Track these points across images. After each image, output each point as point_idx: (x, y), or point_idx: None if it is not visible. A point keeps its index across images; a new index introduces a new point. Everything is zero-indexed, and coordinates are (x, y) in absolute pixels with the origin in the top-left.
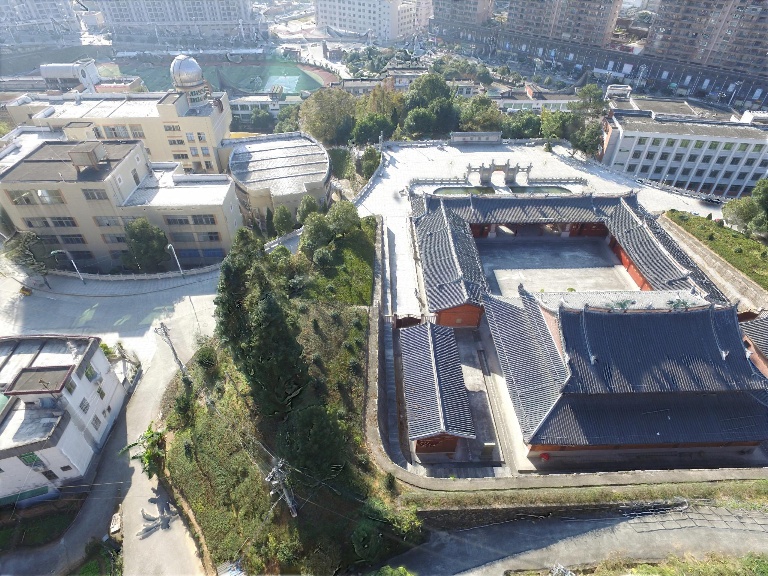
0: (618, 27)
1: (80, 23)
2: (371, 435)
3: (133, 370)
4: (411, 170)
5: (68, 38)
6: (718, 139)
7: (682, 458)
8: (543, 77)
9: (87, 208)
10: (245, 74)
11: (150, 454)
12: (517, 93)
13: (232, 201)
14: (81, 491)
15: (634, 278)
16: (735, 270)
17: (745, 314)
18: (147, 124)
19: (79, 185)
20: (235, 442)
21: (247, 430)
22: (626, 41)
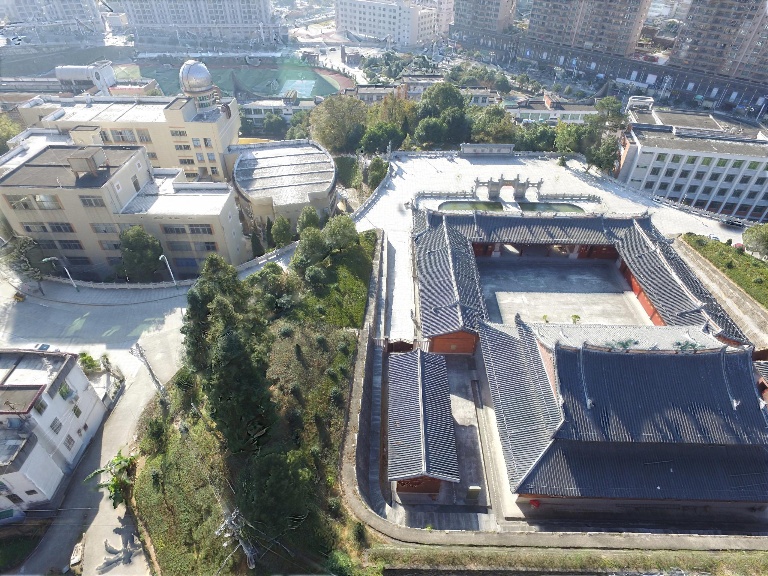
0: (643, 36)
1: (105, 24)
2: (347, 474)
3: (116, 385)
4: (418, 182)
5: (92, 39)
6: (742, 158)
7: (685, 512)
8: (563, 86)
9: (84, 214)
10: (262, 77)
11: (117, 482)
12: (535, 102)
13: (231, 210)
14: (46, 516)
15: (644, 306)
16: (754, 302)
17: (763, 352)
18: (154, 129)
19: (76, 191)
20: (202, 476)
21: (215, 464)
22: (651, 51)
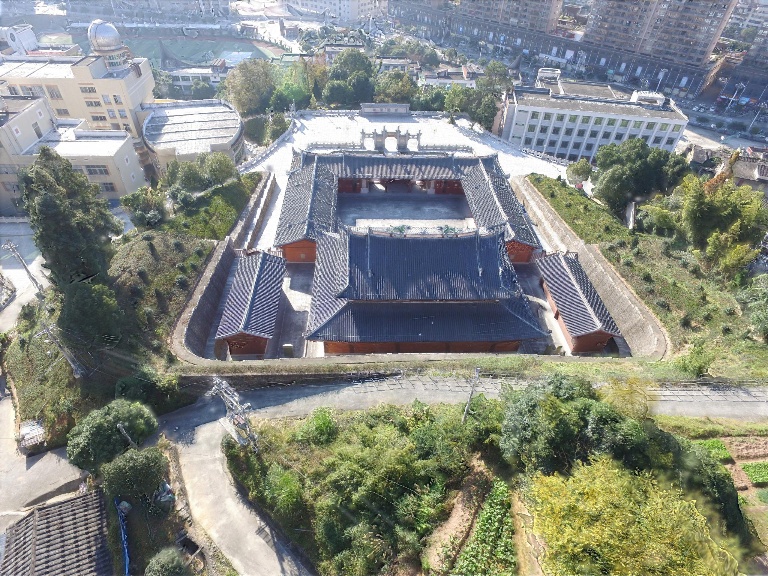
0: (567, 14)
1: None
2: (178, 332)
3: (6, 294)
4: (317, 136)
5: (22, 7)
6: (601, 115)
7: None
8: (488, 60)
9: None
10: (199, 48)
11: None
12: (454, 73)
13: (129, 155)
14: None
15: None
16: (562, 221)
17: None
18: (63, 85)
19: None
20: None
21: None
22: (572, 28)
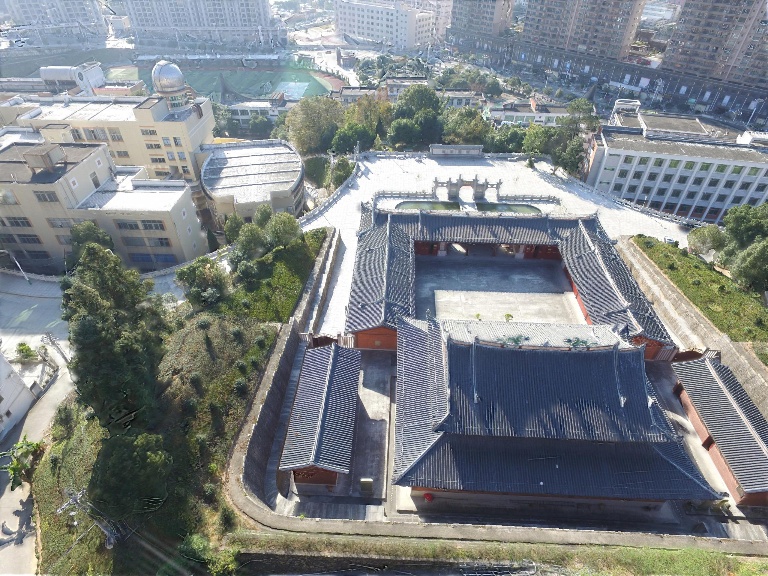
0: (639, 39)
1: (108, 27)
2: (235, 463)
3: (48, 374)
4: (382, 182)
5: (94, 41)
6: (709, 160)
7: (579, 510)
8: (554, 89)
9: (40, 209)
10: (257, 79)
11: (18, 465)
12: (521, 105)
13: (186, 207)
14: None
15: (581, 306)
16: (690, 304)
17: (688, 353)
18: (125, 128)
19: (30, 187)
20: (92, 461)
21: None
22: (646, 54)
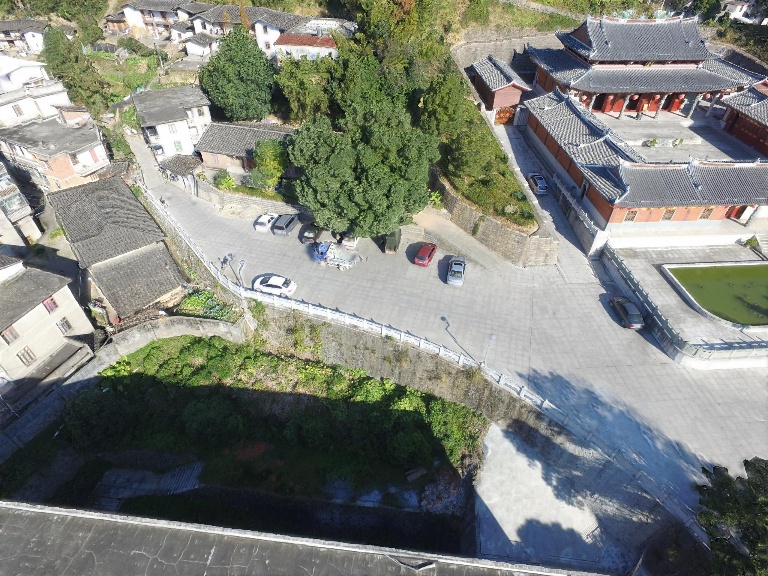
0: None
1: None
2: None
3: None
4: None
5: None
6: (217, 533)
7: None
8: None
9: None
10: None
11: None
12: None
13: None
14: None
15: None
16: None
17: (507, 112)
18: None
19: None
20: None
21: None
22: None
